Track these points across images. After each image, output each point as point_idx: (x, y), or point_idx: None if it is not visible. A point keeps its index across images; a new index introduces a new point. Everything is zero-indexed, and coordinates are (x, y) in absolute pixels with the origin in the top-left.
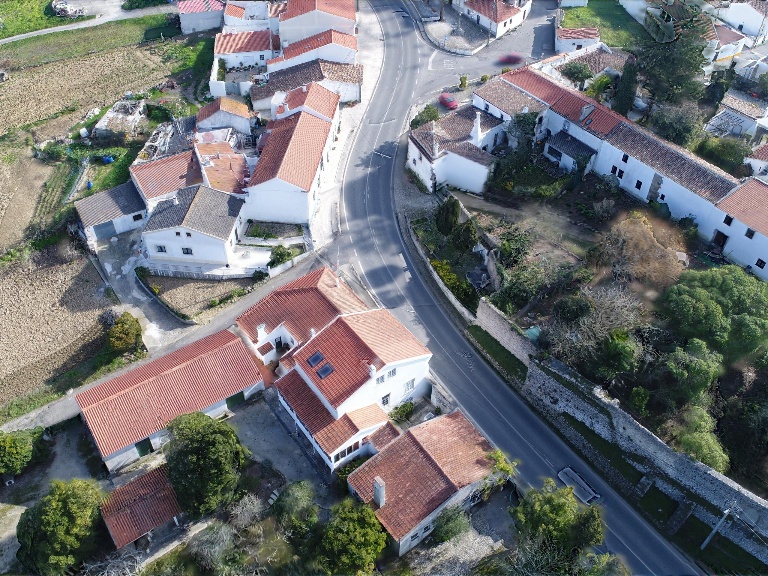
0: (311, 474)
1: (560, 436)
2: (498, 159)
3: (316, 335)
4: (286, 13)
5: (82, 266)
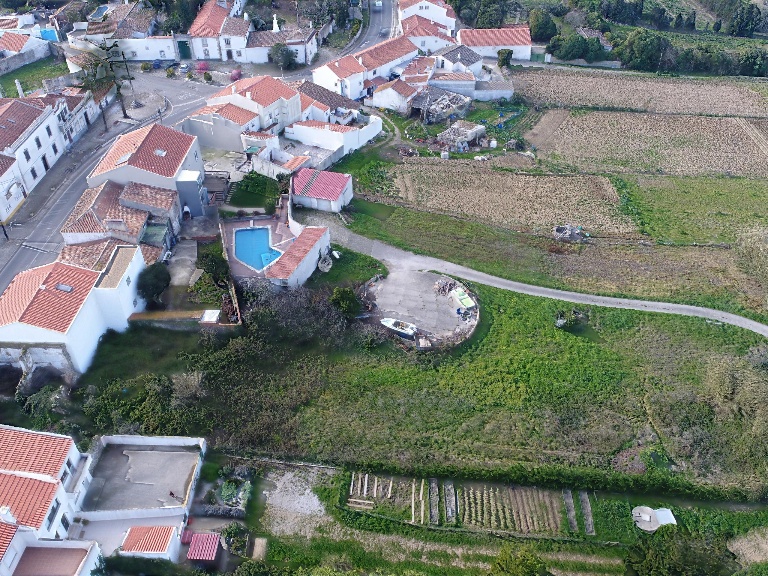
0: (456, 26)
1: (370, 9)
2: (283, 24)
3: (436, 5)
4: (284, 96)
5: (518, 91)
